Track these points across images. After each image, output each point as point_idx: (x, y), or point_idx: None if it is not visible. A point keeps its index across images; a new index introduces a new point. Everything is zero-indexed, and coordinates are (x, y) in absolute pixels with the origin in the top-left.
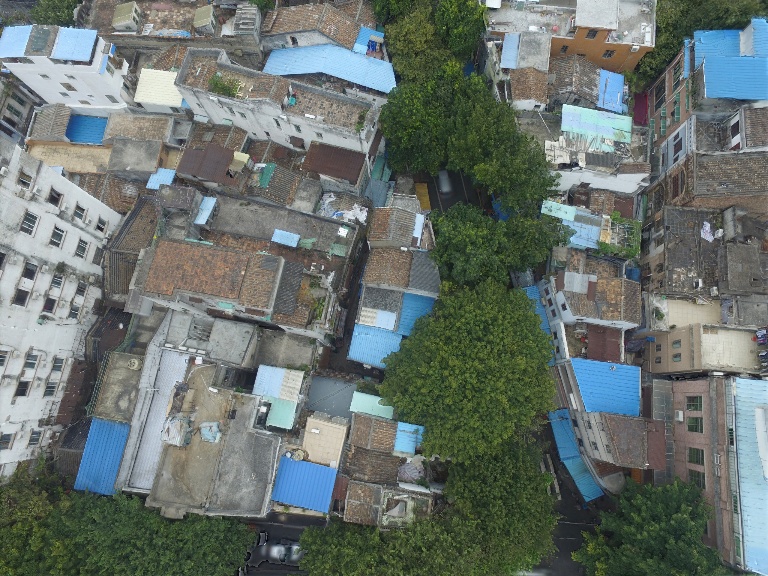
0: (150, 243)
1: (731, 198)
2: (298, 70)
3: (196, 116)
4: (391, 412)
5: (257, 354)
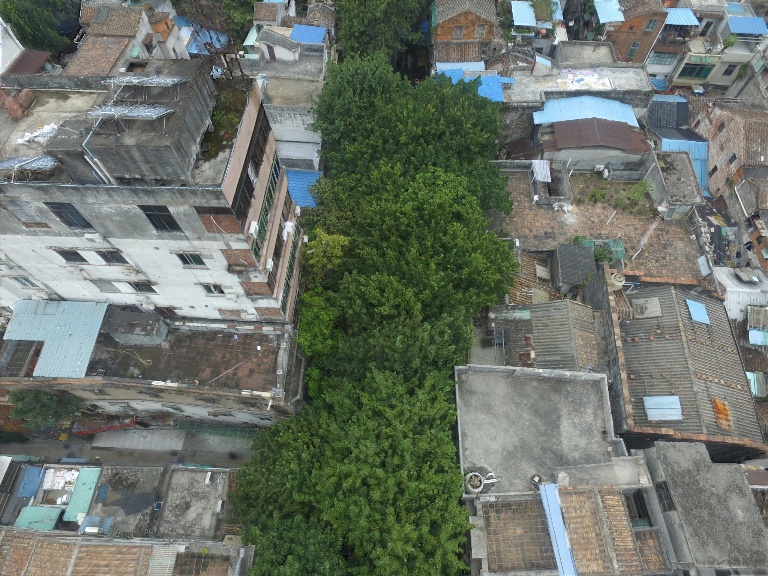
0: None
1: None
2: None
3: None
4: None
5: None
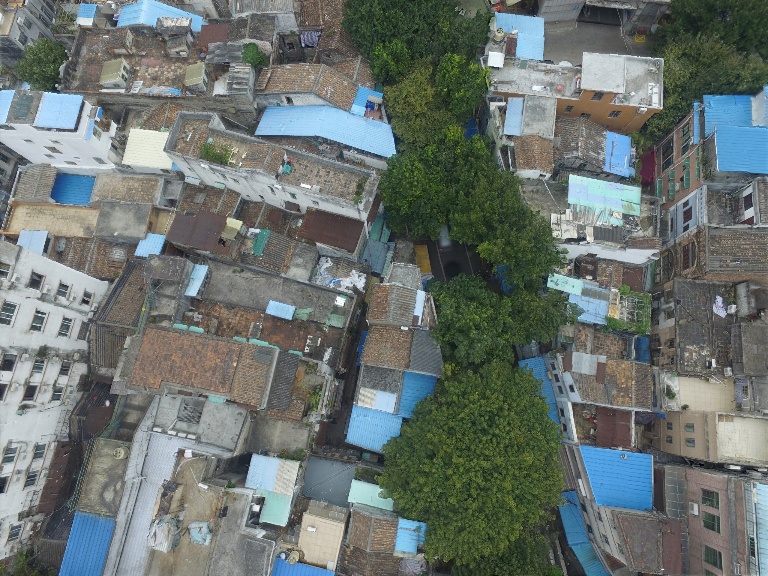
0: (138, 314)
1: (745, 275)
2: (293, 131)
3: (187, 178)
4: (391, 503)
5: (250, 436)
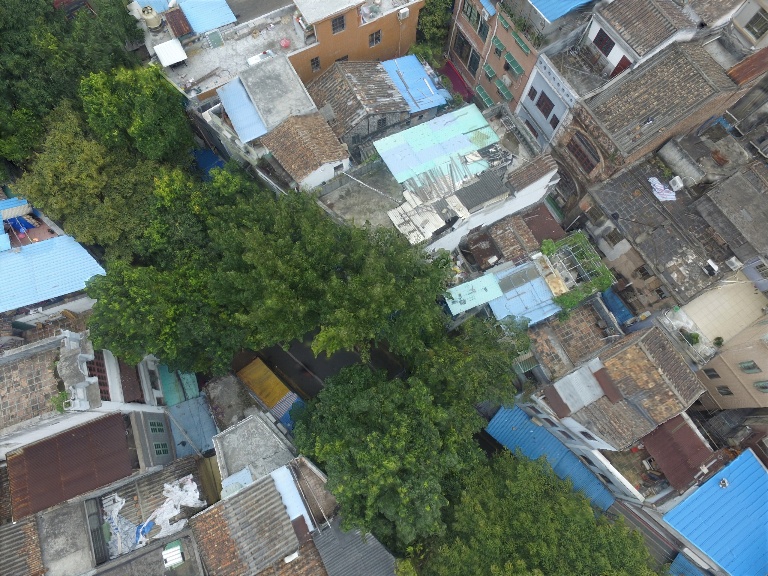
0: None
1: (666, 132)
2: None
3: None
4: None
5: None
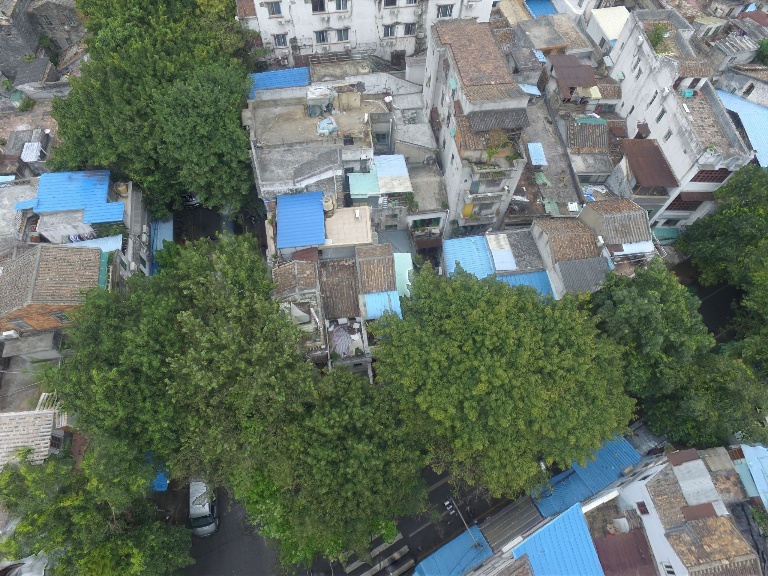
0: None
1: None
2: None
3: (608, 57)
4: (403, 294)
5: (410, 166)
